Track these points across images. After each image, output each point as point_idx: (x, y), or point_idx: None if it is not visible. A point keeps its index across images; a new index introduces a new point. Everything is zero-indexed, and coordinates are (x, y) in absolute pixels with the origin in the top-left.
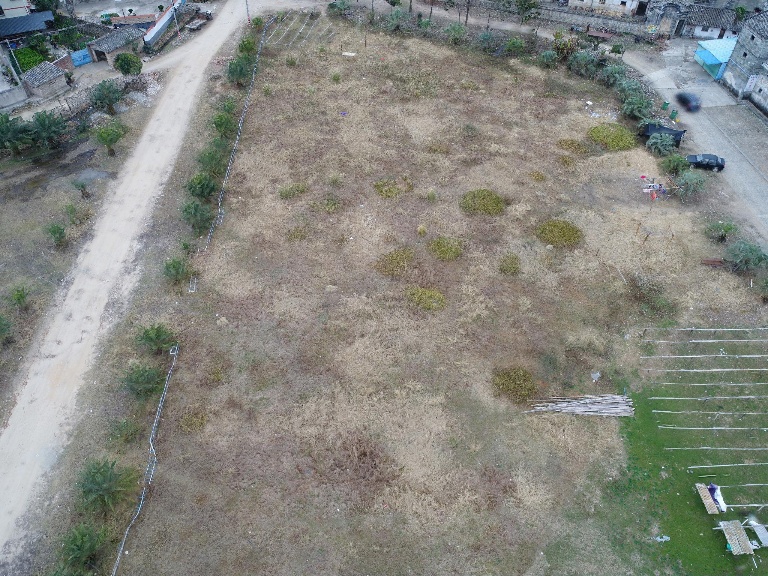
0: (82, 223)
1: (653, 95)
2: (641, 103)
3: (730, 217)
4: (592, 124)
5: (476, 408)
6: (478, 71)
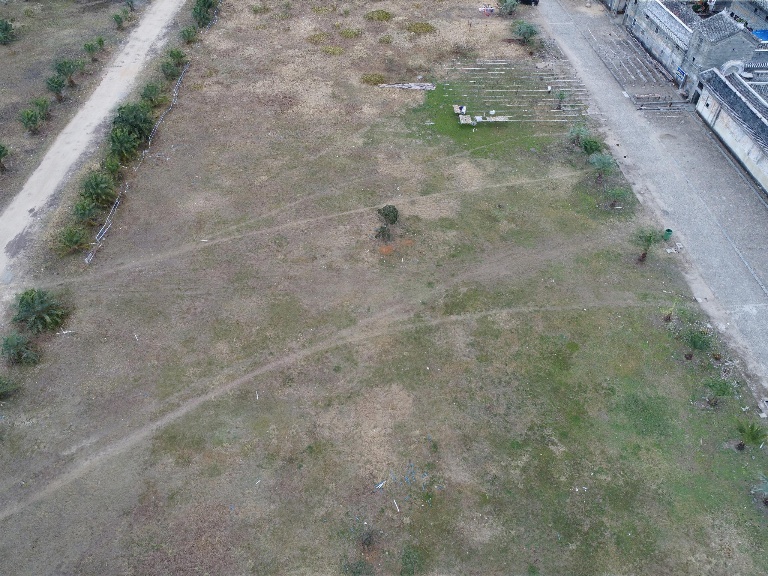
0: (132, 20)
1: None
2: None
3: (531, 24)
4: None
5: (350, 86)
6: None
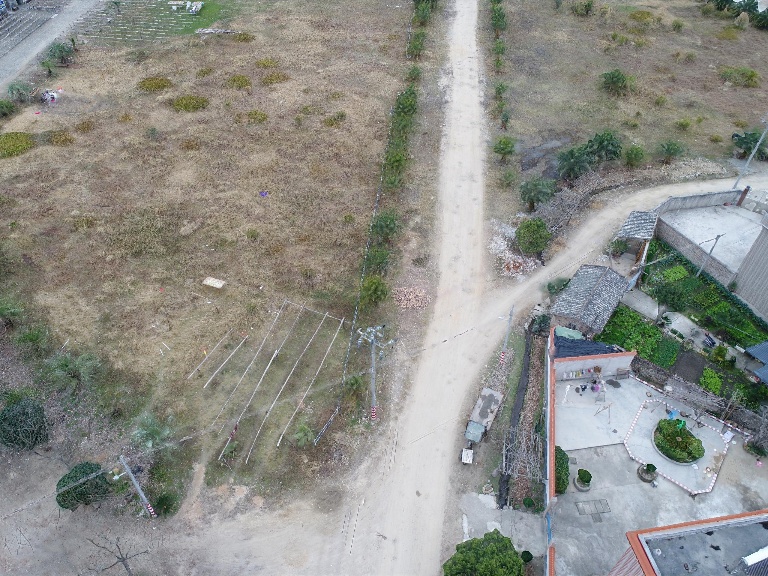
0: None
1: None
2: None
3: None
4: (7, 161)
5: None
6: (42, 251)
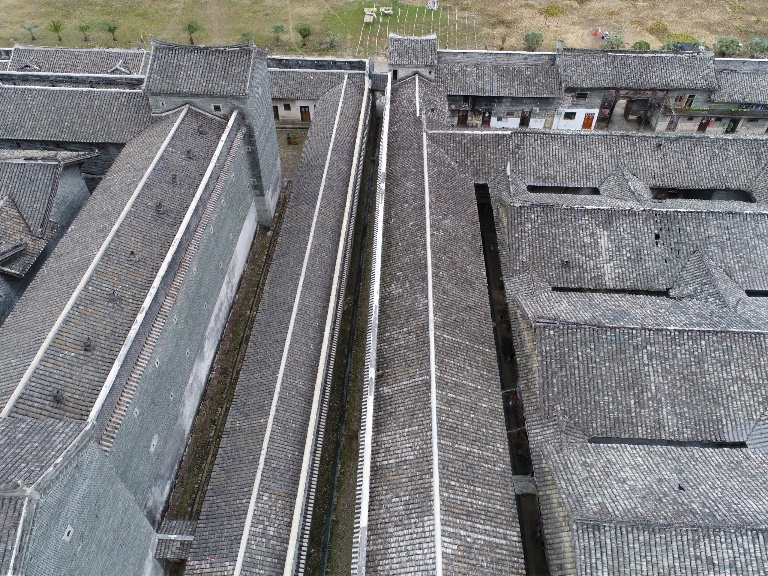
0: None
1: None
2: (727, 41)
3: None
4: (700, 39)
5: None
6: (767, 12)
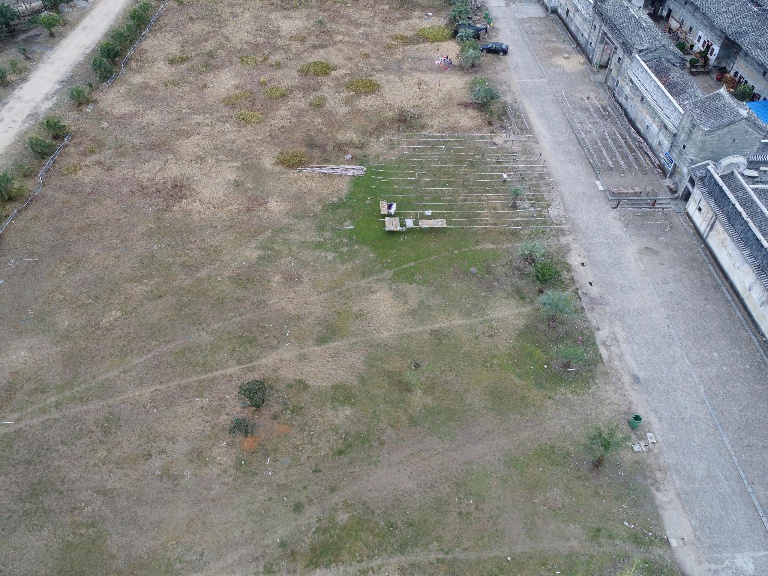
0: (21, 73)
1: (482, 9)
2: (461, 10)
3: (495, 81)
4: (424, 26)
5: (260, 169)
6: None
